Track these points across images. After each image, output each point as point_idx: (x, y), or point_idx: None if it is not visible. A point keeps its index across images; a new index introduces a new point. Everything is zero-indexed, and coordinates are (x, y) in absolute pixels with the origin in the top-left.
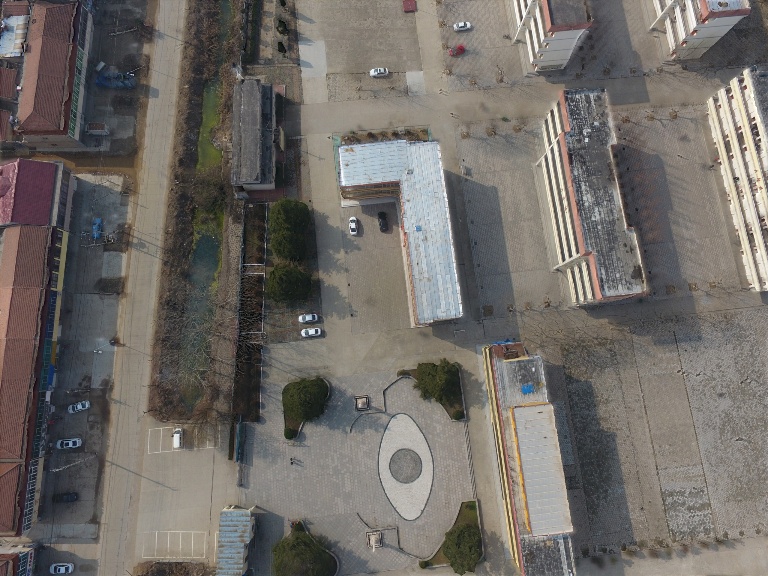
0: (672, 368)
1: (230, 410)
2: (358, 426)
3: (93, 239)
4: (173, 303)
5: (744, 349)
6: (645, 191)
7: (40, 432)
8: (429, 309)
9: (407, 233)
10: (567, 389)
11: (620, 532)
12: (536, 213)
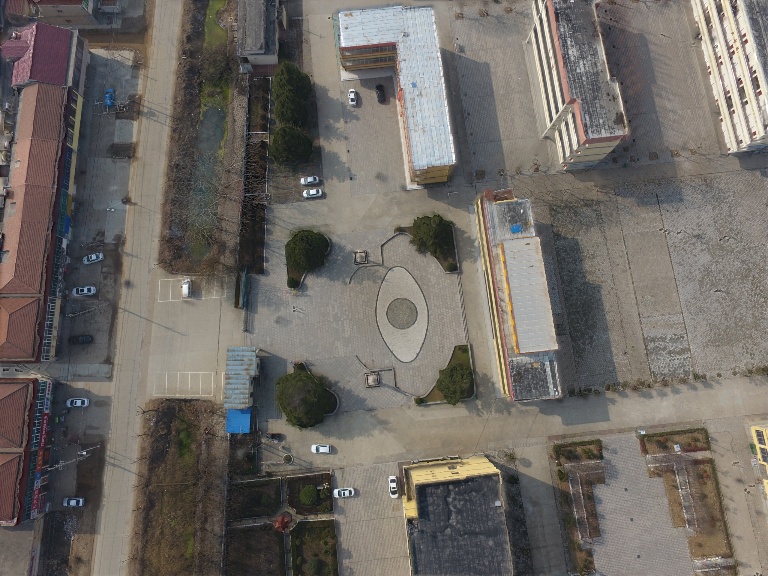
0: (654, 227)
1: (236, 263)
2: (357, 278)
3: (106, 107)
4: (182, 167)
5: (723, 209)
6: (630, 67)
7: (57, 274)
8: (424, 157)
9: (403, 89)
10: (555, 245)
11: (604, 374)
12: (526, 86)
